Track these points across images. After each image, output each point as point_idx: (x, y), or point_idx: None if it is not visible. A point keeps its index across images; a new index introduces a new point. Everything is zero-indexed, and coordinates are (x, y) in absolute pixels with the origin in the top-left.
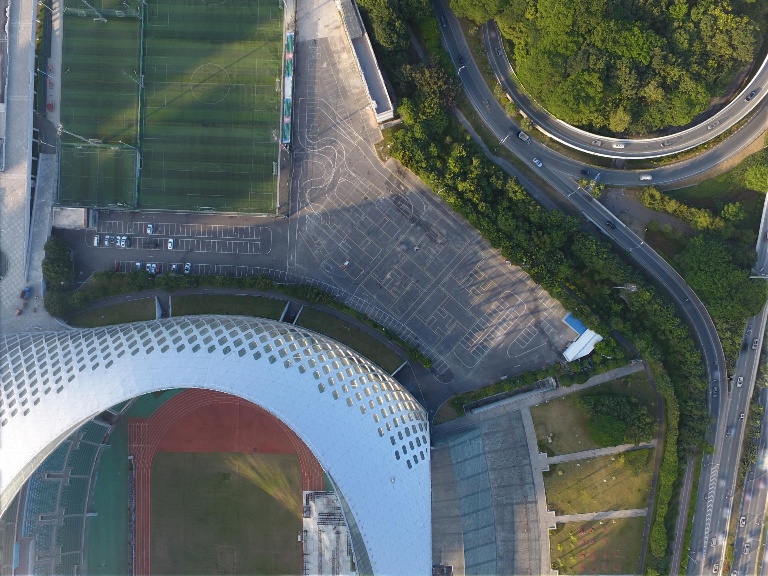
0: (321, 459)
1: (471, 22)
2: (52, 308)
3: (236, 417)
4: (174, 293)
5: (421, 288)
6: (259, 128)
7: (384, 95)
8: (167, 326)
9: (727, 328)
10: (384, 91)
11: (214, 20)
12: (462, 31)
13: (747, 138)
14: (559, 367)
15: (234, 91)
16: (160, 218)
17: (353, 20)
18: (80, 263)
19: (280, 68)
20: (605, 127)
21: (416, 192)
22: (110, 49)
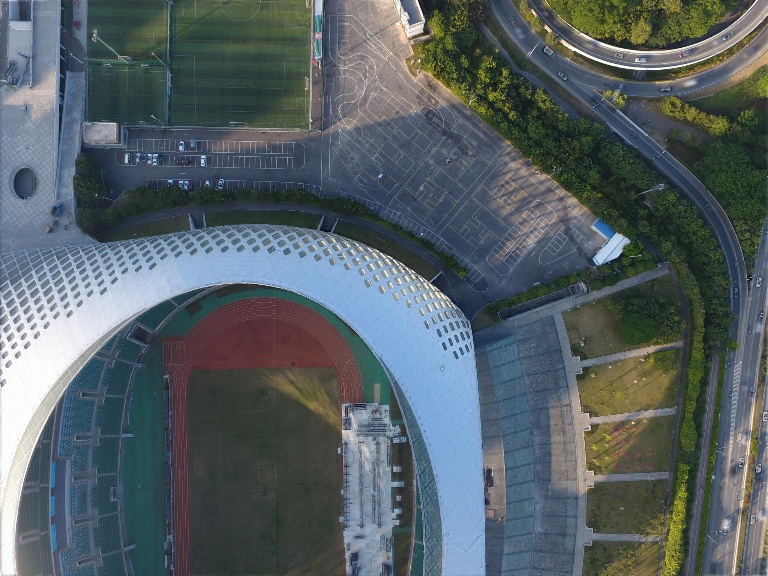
0: (373, 346)
1: None
2: (85, 223)
3: (273, 332)
4: (207, 210)
5: (454, 199)
6: (290, 44)
7: (415, 7)
8: (208, 232)
9: (746, 229)
10: (415, 3)
11: None
12: None
13: (758, 51)
14: (589, 272)
15: (264, 8)
16: (192, 135)
17: None
18: (110, 182)
19: None
20: (626, 40)
21: (447, 105)
22: None
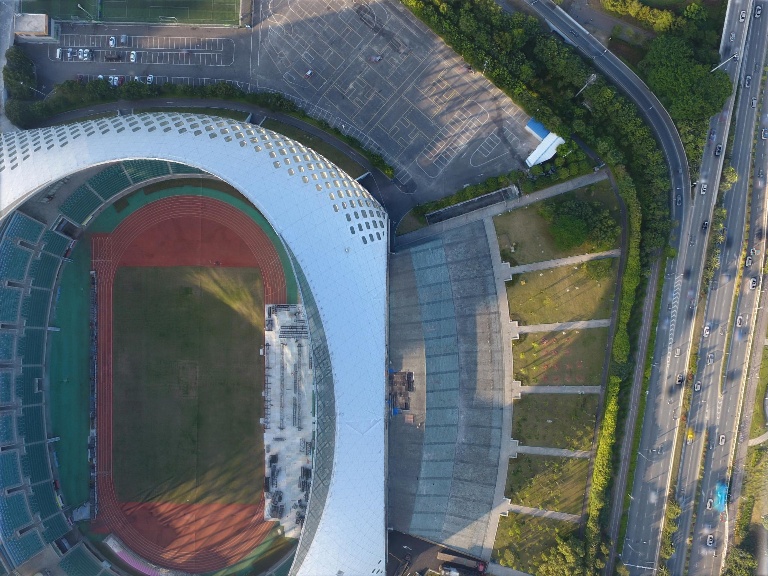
0: (273, 222)
1: None
2: (13, 113)
3: (198, 231)
4: (137, 106)
5: (384, 98)
6: None
7: None
8: (125, 116)
9: (690, 131)
10: None
11: None
12: None
13: None
14: (522, 175)
15: None
16: (123, 31)
17: None
18: (43, 77)
19: None
20: None
21: (379, 1)
22: None
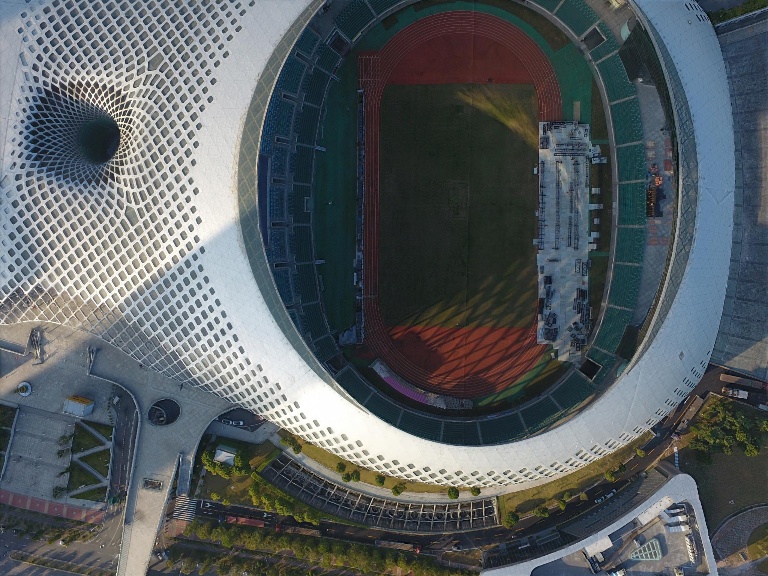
0: None
1: None
2: None
3: (470, 47)
4: None
5: None
6: None
7: None
8: None
9: None
10: None
11: None
12: None
13: None
14: None
15: None
16: None
17: None
18: None
19: None
20: None
21: None
22: None
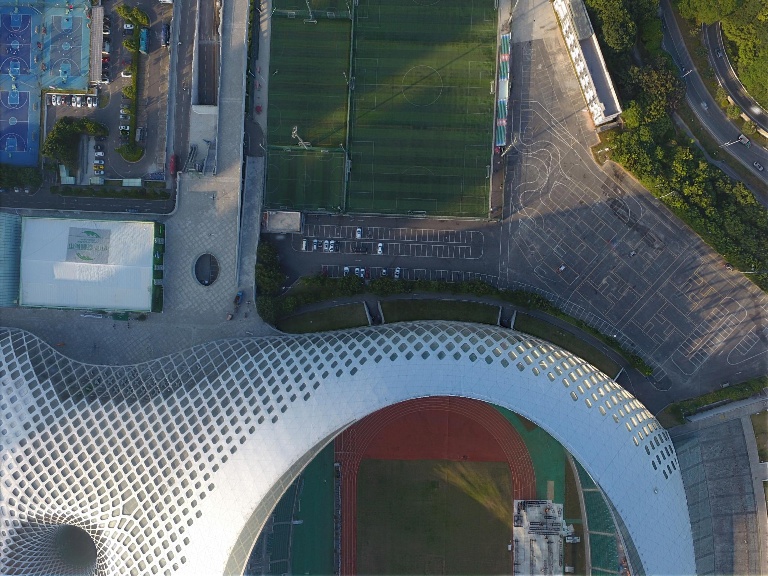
0: (590, 469)
1: (692, 23)
2: (267, 313)
3: (445, 424)
4: (382, 298)
5: (638, 294)
6: (472, 131)
7: (611, 97)
8: (401, 332)
9: None
10: (611, 93)
11: (426, 21)
12: (680, 32)
13: None
14: None
15: (446, 93)
16: (369, 222)
17: (582, 21)
18: (286, 267)
19: (494, 70)
20: None
21: (633, 196)
22: (321, 51)
